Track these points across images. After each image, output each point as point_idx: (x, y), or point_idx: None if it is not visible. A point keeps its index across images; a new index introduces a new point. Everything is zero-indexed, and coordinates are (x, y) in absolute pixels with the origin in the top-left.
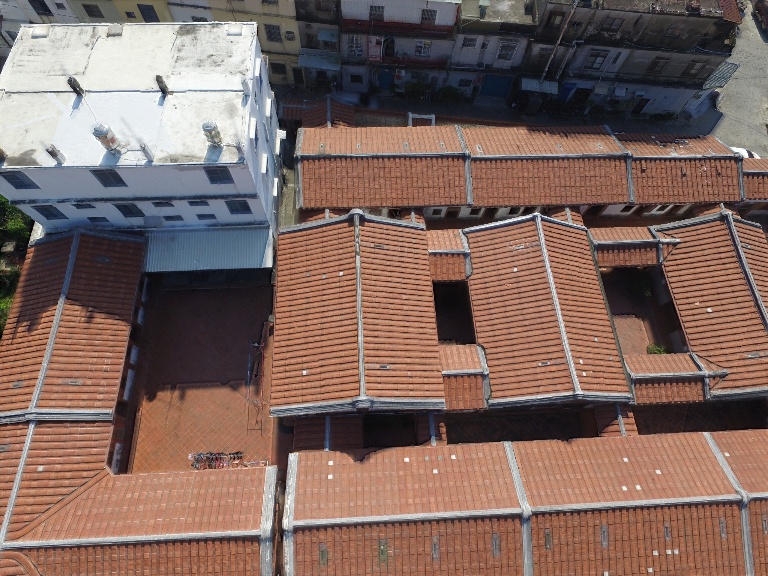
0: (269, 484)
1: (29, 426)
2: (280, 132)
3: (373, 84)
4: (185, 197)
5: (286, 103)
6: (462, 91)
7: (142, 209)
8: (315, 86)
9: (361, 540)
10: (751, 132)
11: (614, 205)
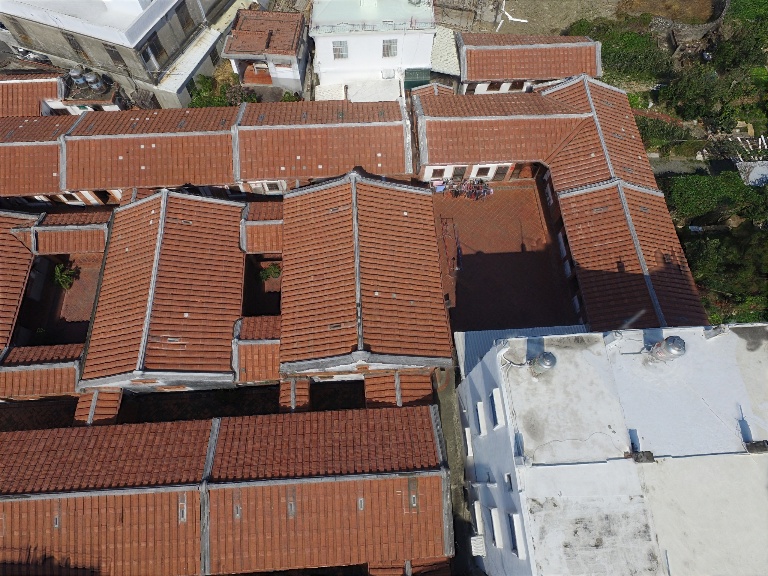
0: (424, 151)
1: None
2: (481, 548)
3: None
4: None
5: None
6: None
7: None
8: None
9: None
10: None
11: None
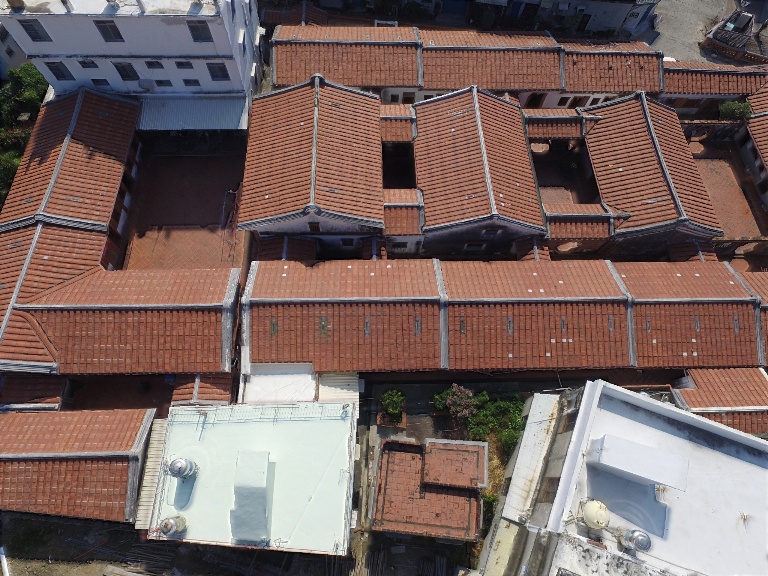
0: (233, 278)
1: (38, 226)
2: (260, 29)
3: (347, 1)
4: (173, 56)
5: (268, 9)
6: (425, 7)
7: (137, 70)
8: (295, 1)
9: (306, 316)
10: (684, 49)
11: (550, 96)
